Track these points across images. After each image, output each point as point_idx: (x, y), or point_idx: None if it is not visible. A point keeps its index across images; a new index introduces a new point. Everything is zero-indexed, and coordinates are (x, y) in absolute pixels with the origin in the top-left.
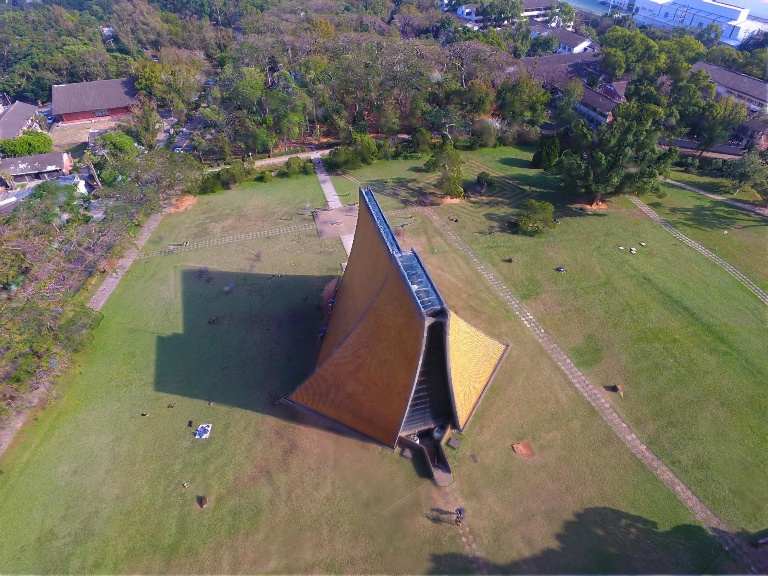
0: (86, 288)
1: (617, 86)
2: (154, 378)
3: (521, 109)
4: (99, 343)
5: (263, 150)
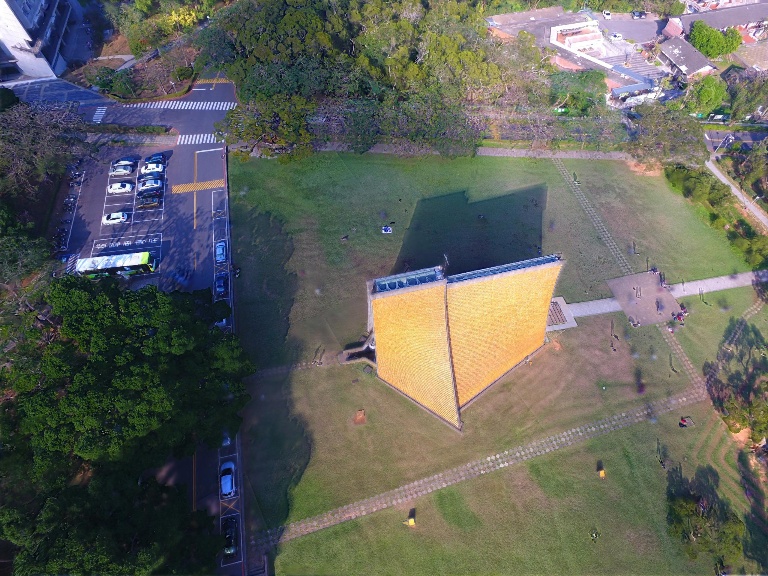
0: (512, 142)
1: None
2: (428, 198)
3: None
4: (458, 165)
5: None
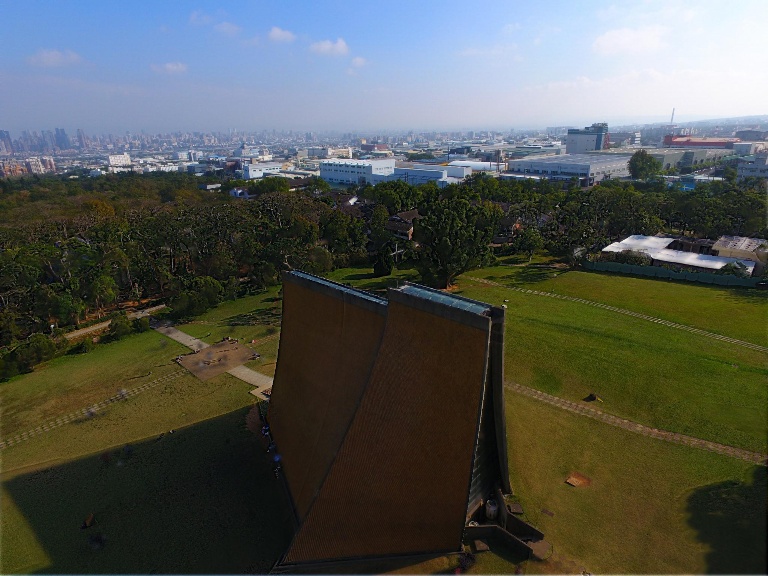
0: None
1: (401, 216)
2: None
3: (343, 236)
4: None
5: (68, 321)
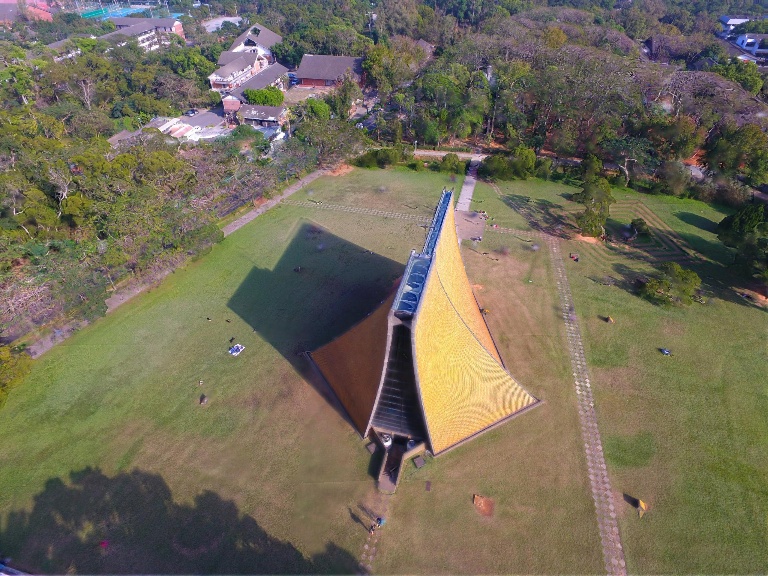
0: (234, 213)
1: None
2: (232, 296)
3: (736, 162)
4: (216, 256)
5: (430, 141)
